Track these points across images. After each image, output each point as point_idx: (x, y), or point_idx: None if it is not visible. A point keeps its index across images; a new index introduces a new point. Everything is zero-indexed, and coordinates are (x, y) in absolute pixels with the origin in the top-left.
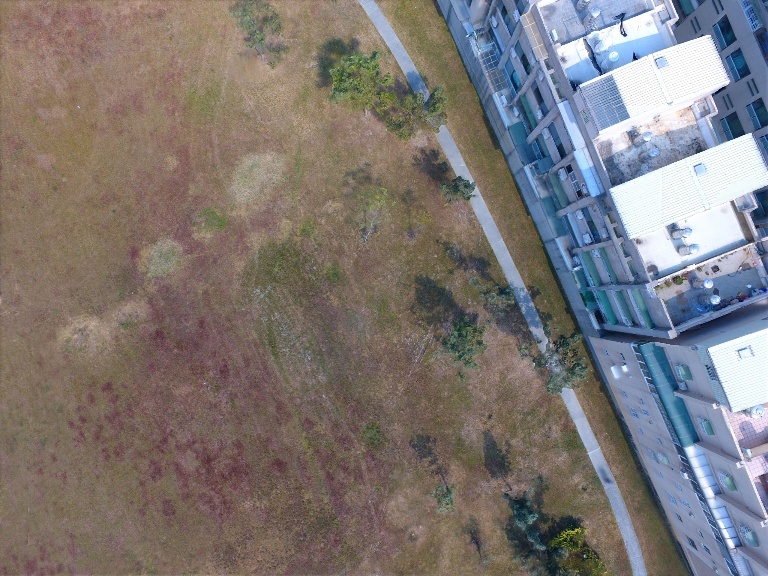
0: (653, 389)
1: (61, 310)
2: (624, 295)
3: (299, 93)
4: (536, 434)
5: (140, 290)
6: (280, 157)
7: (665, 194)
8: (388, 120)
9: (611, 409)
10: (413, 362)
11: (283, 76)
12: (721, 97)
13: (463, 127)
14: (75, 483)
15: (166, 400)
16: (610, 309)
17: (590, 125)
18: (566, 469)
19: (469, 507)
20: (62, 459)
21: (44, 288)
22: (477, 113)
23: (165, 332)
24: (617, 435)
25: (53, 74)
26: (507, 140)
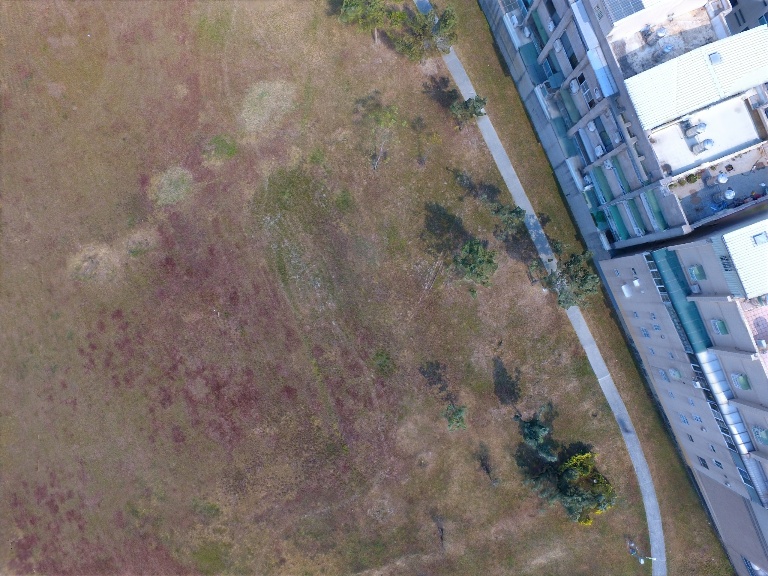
0: (665, 297)
1: (71, 238)
2: (636, 203)
3: (309, 21)
4: (546, 361)
5: (150, 218)
6: (290, 85)
7: (680, 84)
8: (399, 41)
9: (621, 336)
10: (423, 289)
11: (293, 4)
12: (733, 14)
13: (473, 55)
14: (85, 410)
15: (176, 327)
16: (622, 224)
17: (604, 20)
18: (576, 395)
19: (479, 433)
20: (72, 386)
21: (54, 216)
22: (487, 40)
23: (175, 259)
24: (627, 361)
25: (63, 3)
26: (517, 64)
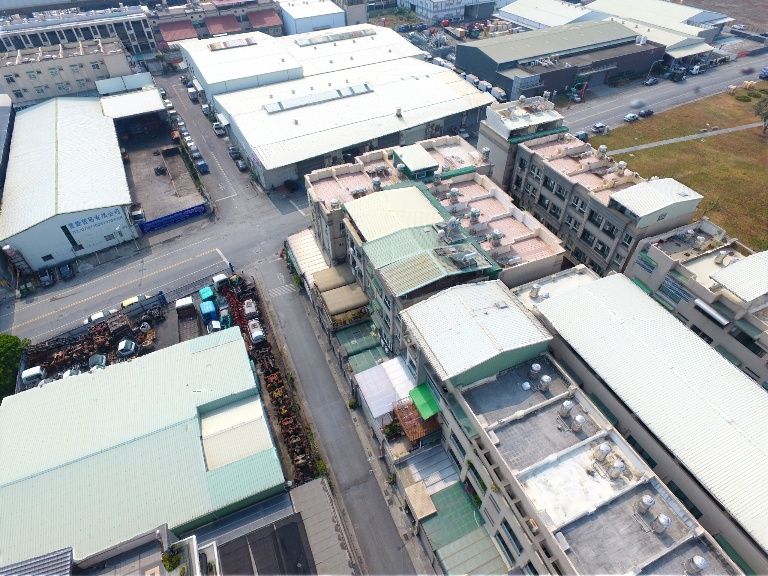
0: None
1: None
2: None
3: None
4: None
5: None
6: None
7: None
8: None
9: None
10: None
11: None
12: None
13: None
14: None
15: None
16: None
17: None
18: None
19: None
20: None
21: None
22: None
23: None
24: None
25: None
26: None
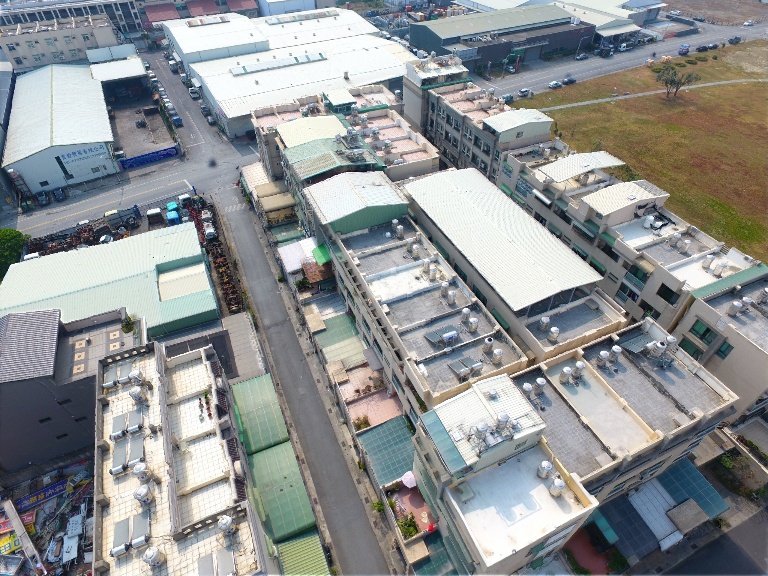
0: None
1: None
2: None
3: None
4: None
5: None
6: None
7: None
8: None
9: None
10: None
11: None
12: None
13: None
14: None
15: None
16: None
17: None
18: None
19: None
20: None
21: None
22: None
23: None
24: None
25: None
26: None
